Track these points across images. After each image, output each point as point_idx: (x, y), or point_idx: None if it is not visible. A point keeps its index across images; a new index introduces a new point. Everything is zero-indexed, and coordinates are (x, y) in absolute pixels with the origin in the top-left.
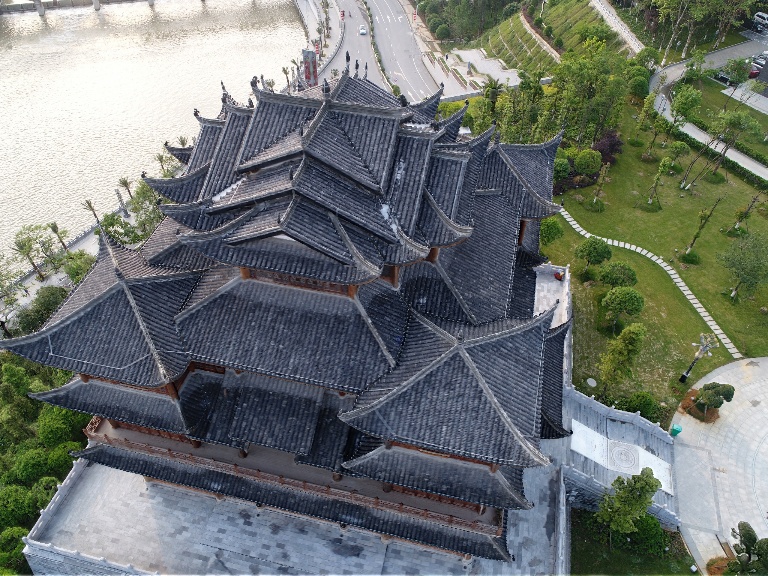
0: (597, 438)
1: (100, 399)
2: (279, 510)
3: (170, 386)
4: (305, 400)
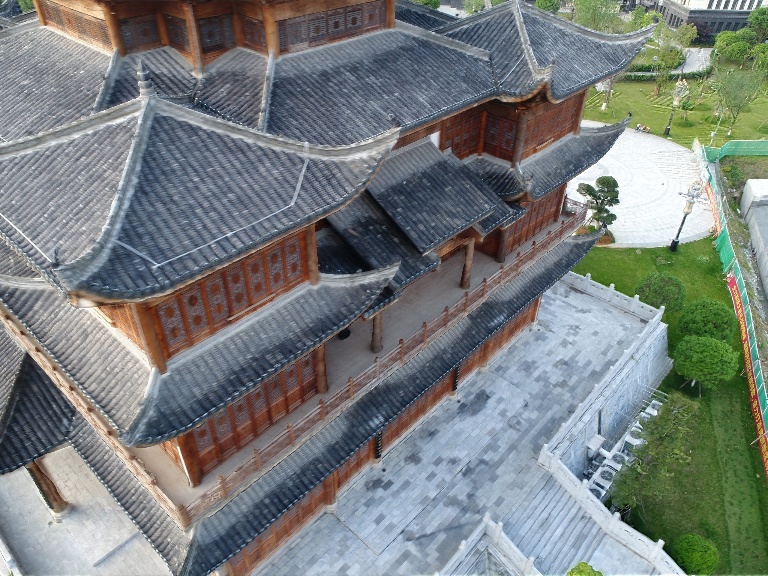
0: None
1: (214, 374)
2: (395, 442)
3: (315, 244)
4: (437, 166)
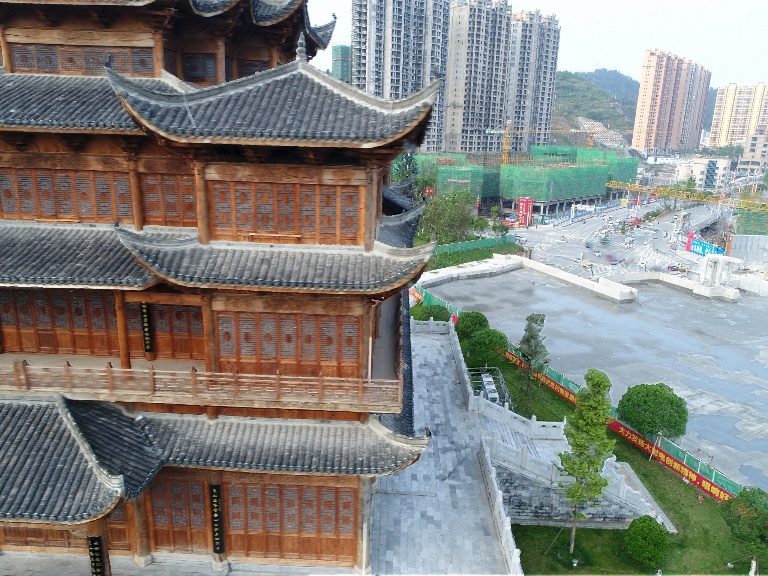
0: None
1: None
2: None
3: None
4: None
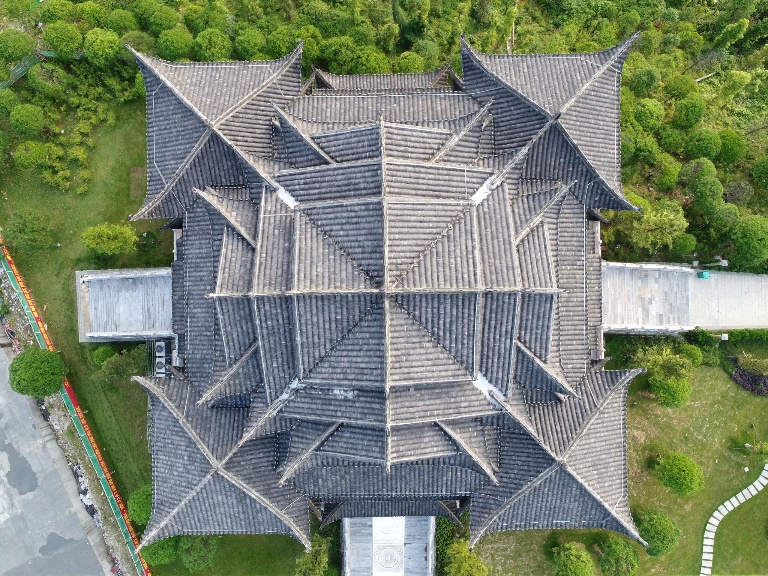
0: (398, 535)
1: None
2: None
3: None
4: None
